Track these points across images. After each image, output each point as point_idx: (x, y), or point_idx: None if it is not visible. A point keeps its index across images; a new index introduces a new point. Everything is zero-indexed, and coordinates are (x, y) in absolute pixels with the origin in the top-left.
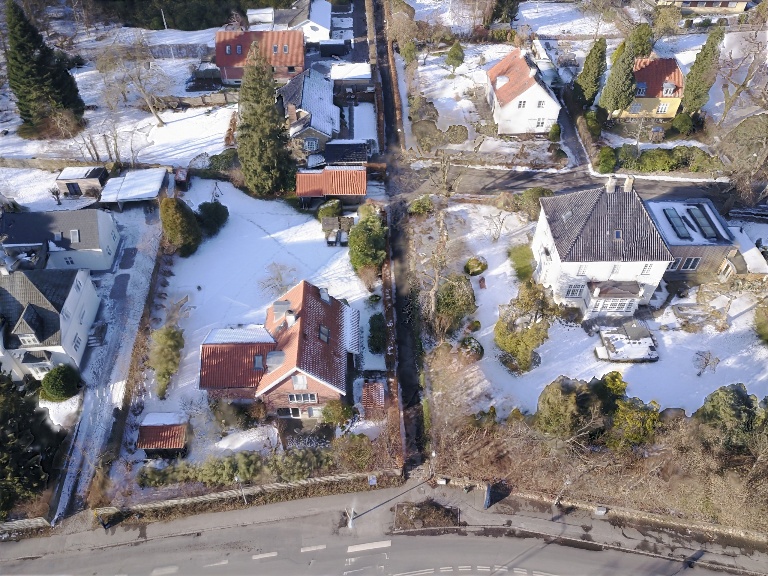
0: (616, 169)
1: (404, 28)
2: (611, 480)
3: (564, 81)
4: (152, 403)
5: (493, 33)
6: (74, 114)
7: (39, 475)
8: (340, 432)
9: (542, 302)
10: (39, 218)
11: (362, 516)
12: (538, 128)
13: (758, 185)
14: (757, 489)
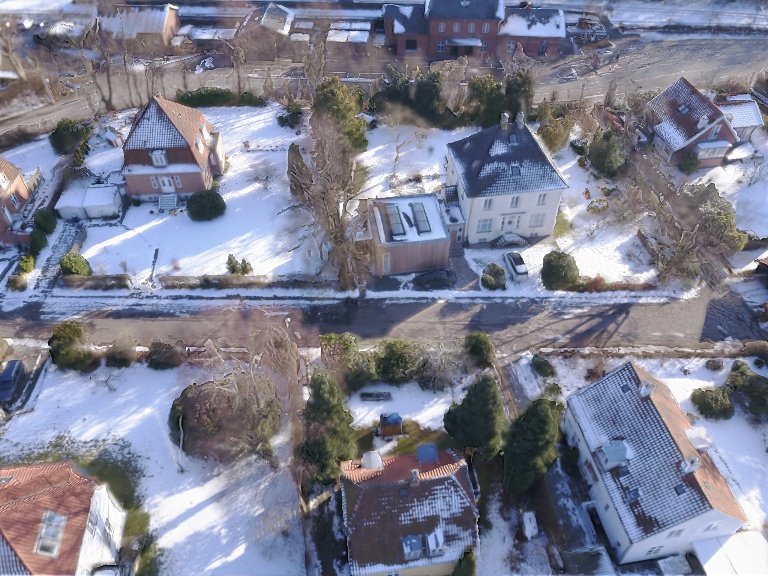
0: None
1: None
2: None
3: None
4: None
5: None
6: None
7: None
8: None
9: None
10: None
11: None
12: None
13: None
14: None
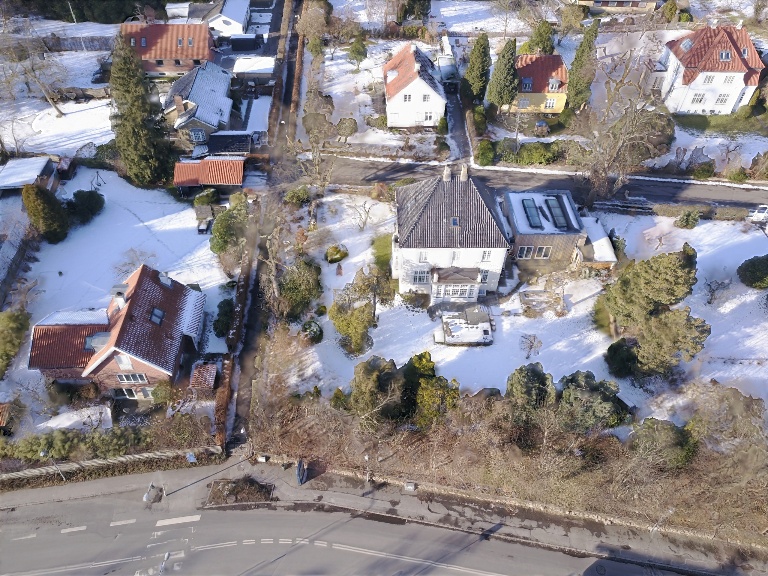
0: (496, 162)
1: (311, 23)
2: None
3: (461, 76)
4: None
5: (404, 29)
6: None
7: None
8: (171, 412)
9: (378, 287)
10: None
11: (177, 492)
12: (426, 122)
13: (612, 177)
14: (560, 465)
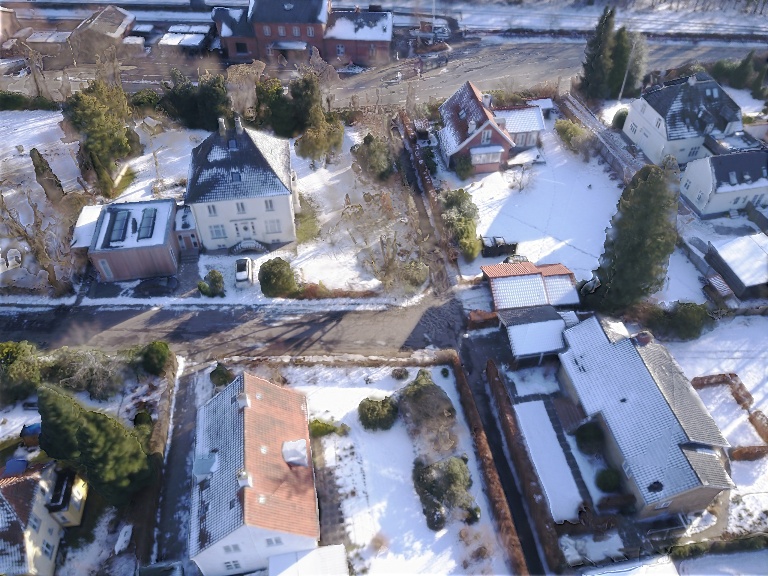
0: None
1: None
2: None
3: None
4: None
5: None
6: None
7: None
8: None
9: None
10: None
11: None
12: None
13: None
14: None
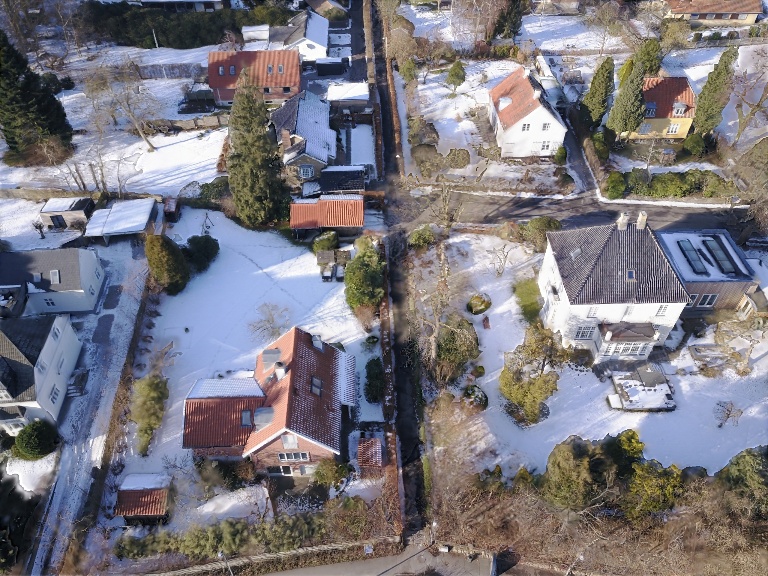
0: (626, 195)
1: (403, 46)
2: (627, 547)
3: (570, 100)
4: (133, 460)
5: (495, 49)
6: (61, 140)
7: (7, 550)
8: (334, 492)
9: (550, 348)
10: (17, 258)
11: None
12: (543, 151)
13: None
14: None
